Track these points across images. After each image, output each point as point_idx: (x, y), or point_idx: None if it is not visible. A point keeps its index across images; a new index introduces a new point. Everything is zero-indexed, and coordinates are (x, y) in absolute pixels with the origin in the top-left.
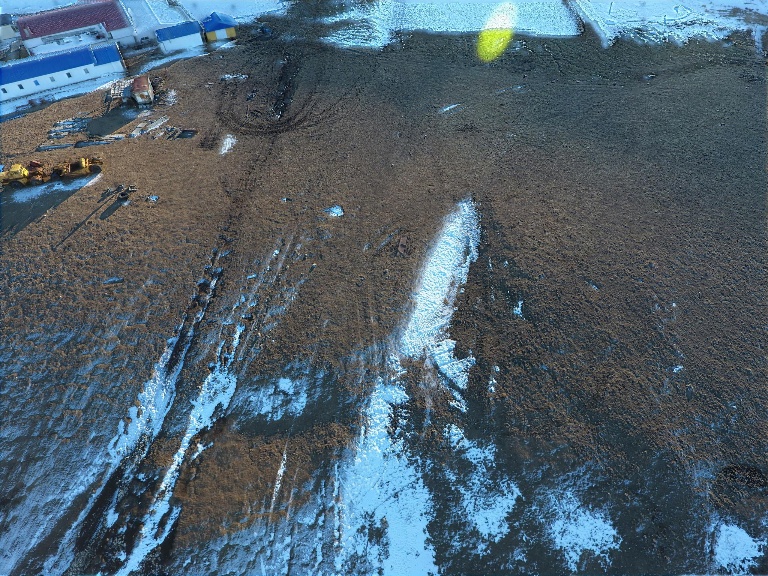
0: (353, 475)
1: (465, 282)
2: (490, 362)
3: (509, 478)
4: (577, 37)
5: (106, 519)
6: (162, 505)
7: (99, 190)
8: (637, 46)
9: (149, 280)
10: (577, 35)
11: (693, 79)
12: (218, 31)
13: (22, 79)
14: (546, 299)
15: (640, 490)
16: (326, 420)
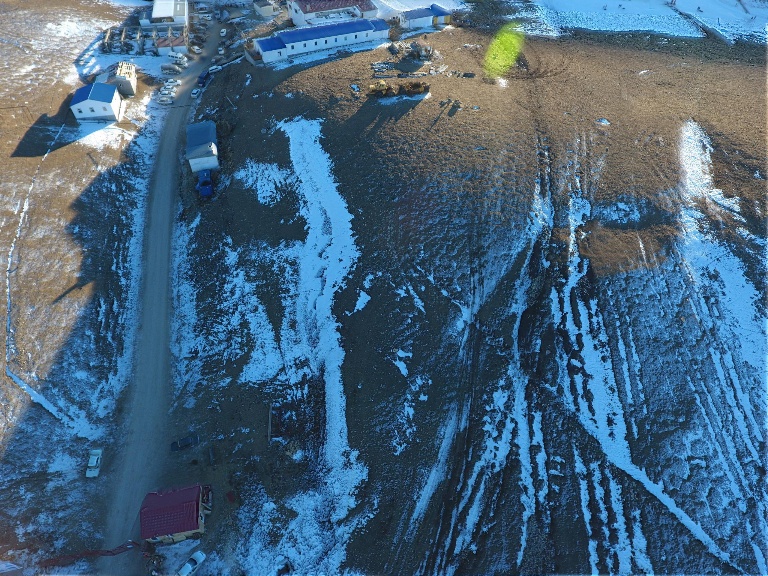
0: (687, 250)
1: (711, 162)
2: (751, 199)
3: None
4: (704, 38)
5: (543, 264)
6: (575, 258)
7: (436, 101)
8: (755, 45)
9: (504, 149)
10: (703, 37)
11: None
12: (440, 17)
13: (330, 36)
14: None
15: None
16: (658, 223)
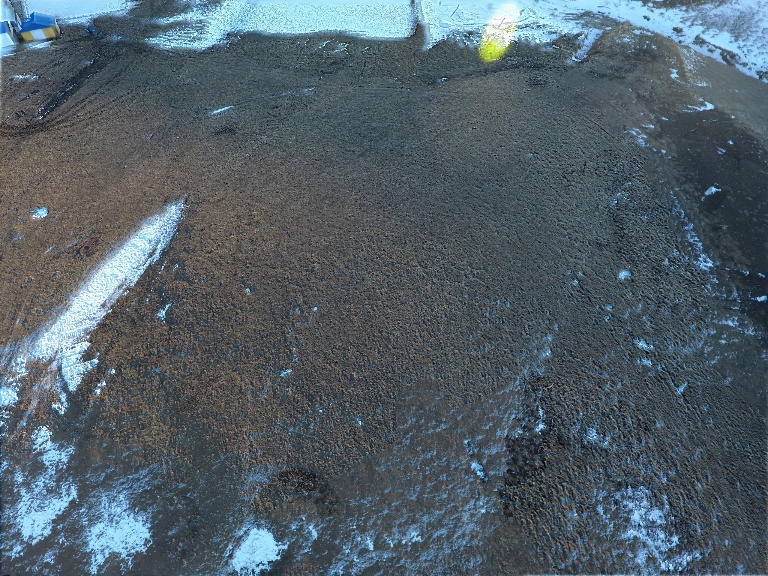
0: None
1: (133, 284)
2: (109, 365)
3: (72, 480)
4: (403, 40)
5: None
6: None
7: None
8: (453, 49)
9: None
10: (405, 38)
11: (479, 83)
12: (33, 31)
13: None
14: (194, 302)
15: (190, 493)
16: None
